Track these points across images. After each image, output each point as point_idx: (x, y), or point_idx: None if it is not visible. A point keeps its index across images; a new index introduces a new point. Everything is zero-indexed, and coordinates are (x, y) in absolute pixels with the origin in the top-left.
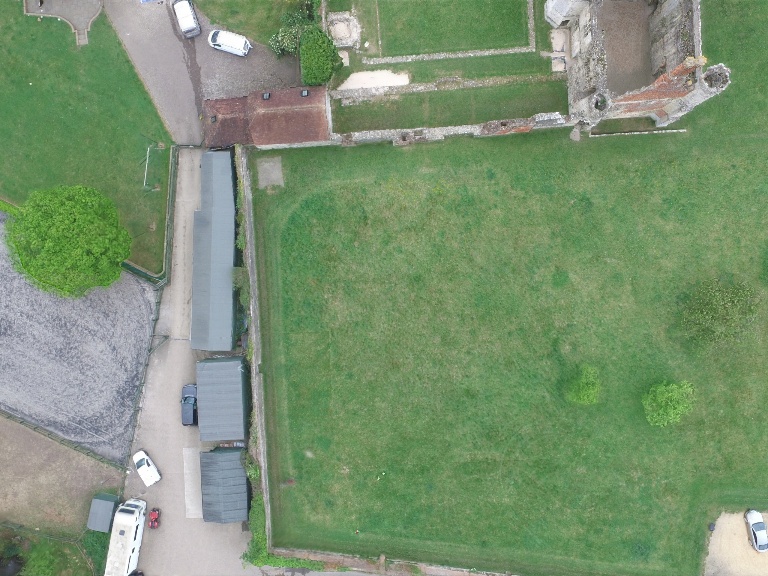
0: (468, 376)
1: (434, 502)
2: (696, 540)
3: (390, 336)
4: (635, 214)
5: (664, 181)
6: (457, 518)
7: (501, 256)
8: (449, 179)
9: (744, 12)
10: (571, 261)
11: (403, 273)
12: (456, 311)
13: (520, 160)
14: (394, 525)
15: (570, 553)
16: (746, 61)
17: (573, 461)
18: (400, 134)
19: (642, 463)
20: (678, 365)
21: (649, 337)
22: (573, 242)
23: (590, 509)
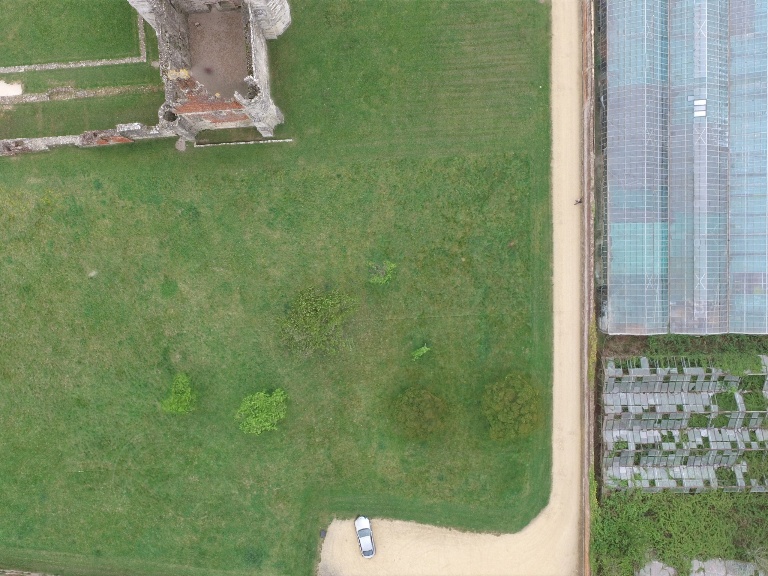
0: (79, 386)
1: (48, 512)
2: (308, 547)
3: (1, 346)
4: (242, 223)
5: (270, 191)
6: (71, 528)
7: (110, 266)
8: (57, 189)
9: (348, 23)
10: (180, 270)
11: (13, 283)
12: (67, 321)
13: (127, 170)
14: (8, 535)
15: (184, 561)
16: (351, 71)
17: (185, 470)
18: (2, 144)
19: (254, 471)
20: (287, 373)
21: (258, 345)
22: (181, 251)
23: (203, 517)
